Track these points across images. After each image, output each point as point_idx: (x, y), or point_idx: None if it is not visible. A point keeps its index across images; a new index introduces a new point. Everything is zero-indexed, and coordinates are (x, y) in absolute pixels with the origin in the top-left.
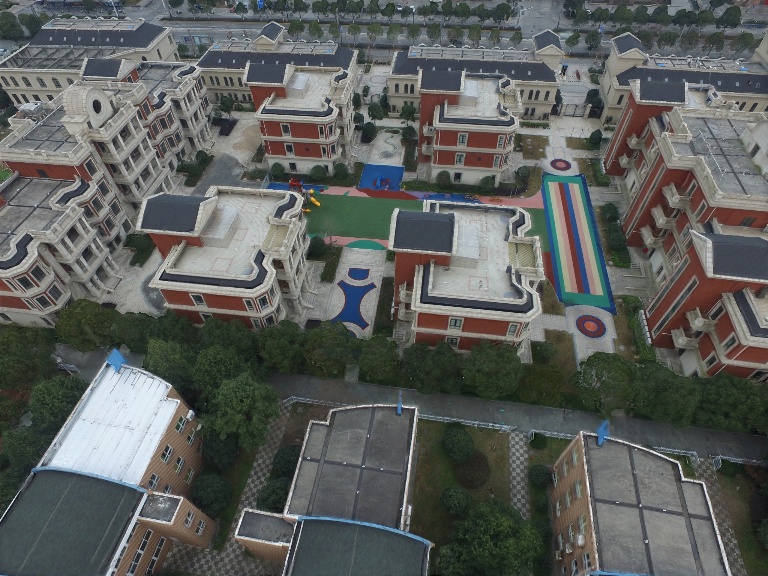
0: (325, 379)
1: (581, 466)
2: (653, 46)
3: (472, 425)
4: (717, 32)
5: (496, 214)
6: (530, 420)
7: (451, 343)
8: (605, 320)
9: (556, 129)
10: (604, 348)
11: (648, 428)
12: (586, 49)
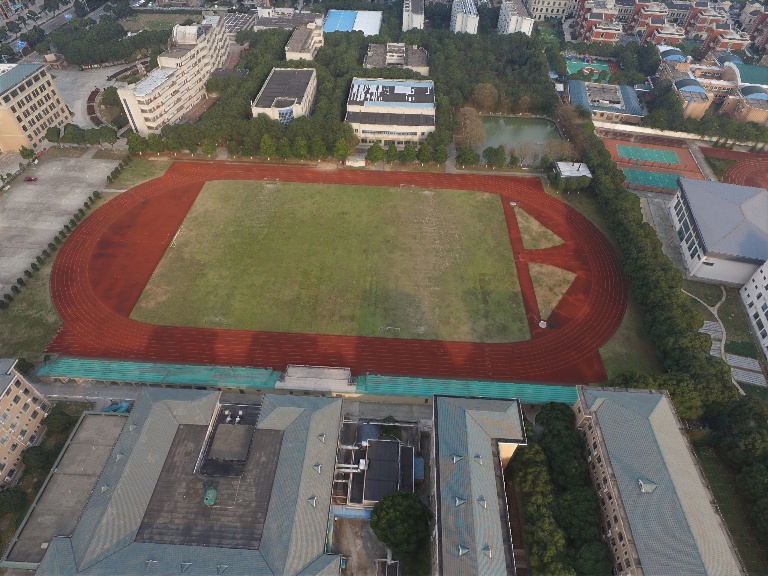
0: None
1: (765, 59)
2: None
3: None
4: None
5: None
6: None
7: None
8: None
9: None
10: None
11: None
12: (728, 11)
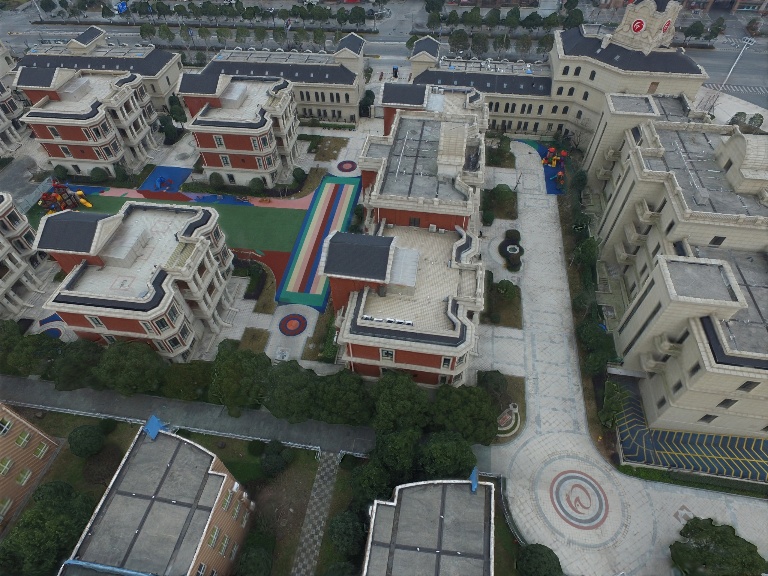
0: (9, 377)
1: None
2: (489, 49)
3: (126, 421)
4: (547, 35)
5: (186, 215)
6: (186, 416)
7: (114, 341)
8: (310, 319)
9: (361, 131)
10: (294, 346)
11: (296, 424)
12: None
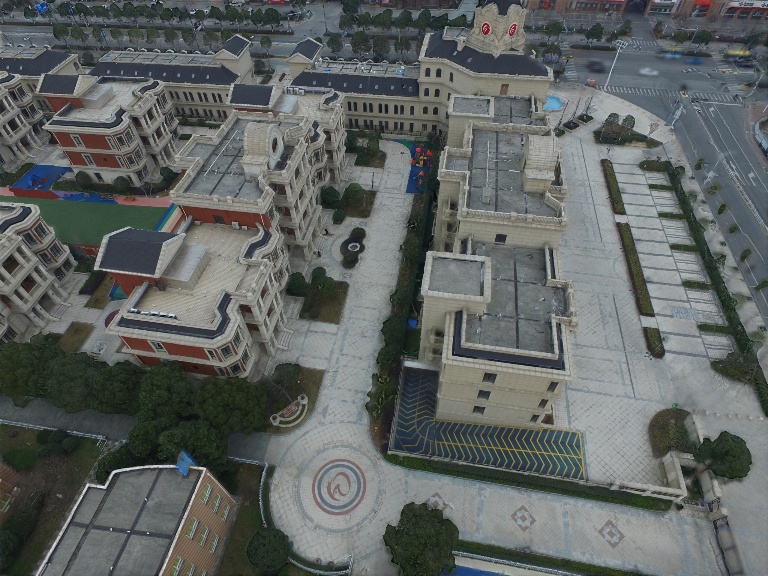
0: None
1: None
2: (390, 50)
3: None
4: None
5: (8, 212)
6: None
7: None
8: None
9: None
10: (114, 340)
11: (92, 414)
12: (332, 53)
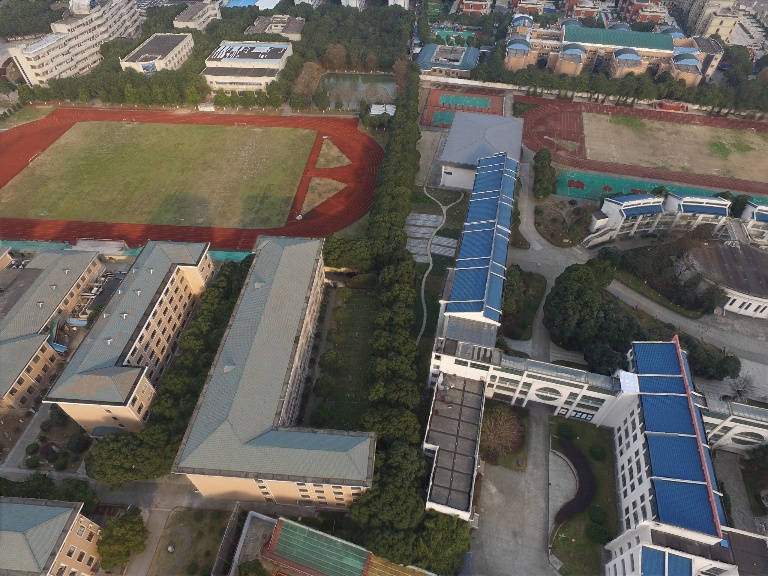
0: None
1: (607, 23)
2: None
3: None
4: None
5: (590, 0)
6: None
7: None
8: None
9: (604, 4)
10: None
11: None
12: None
